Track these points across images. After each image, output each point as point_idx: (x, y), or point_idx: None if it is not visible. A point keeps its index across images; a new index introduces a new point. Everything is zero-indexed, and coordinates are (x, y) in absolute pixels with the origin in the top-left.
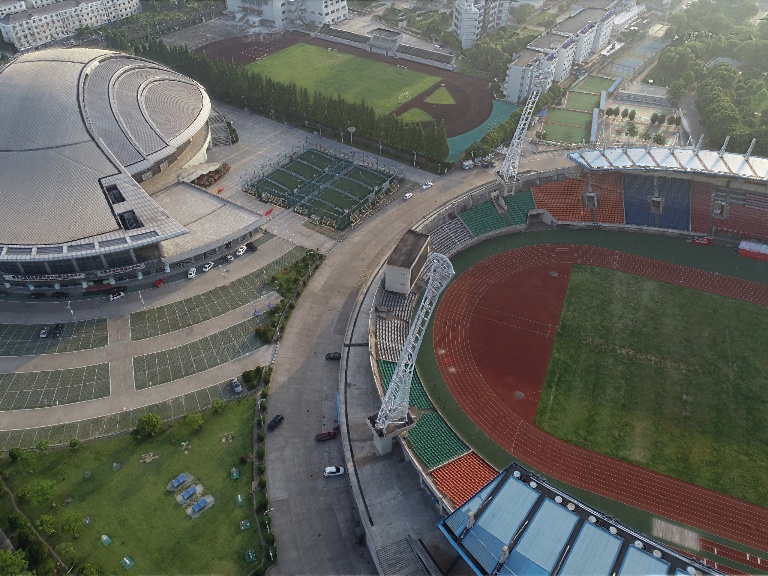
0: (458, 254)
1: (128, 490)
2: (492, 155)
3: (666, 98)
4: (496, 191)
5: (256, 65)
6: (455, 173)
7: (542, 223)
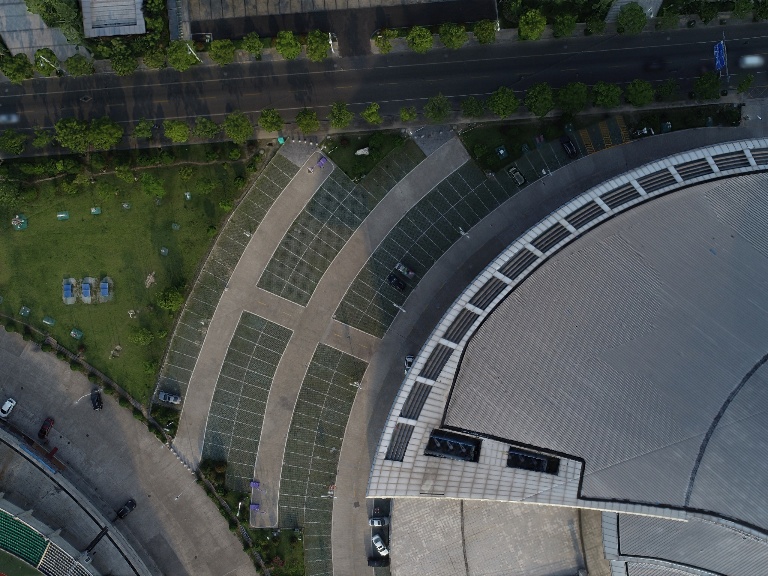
0: None
1: (131, 248)
2: None
3: None
4: None
5: None
6: None
7: None
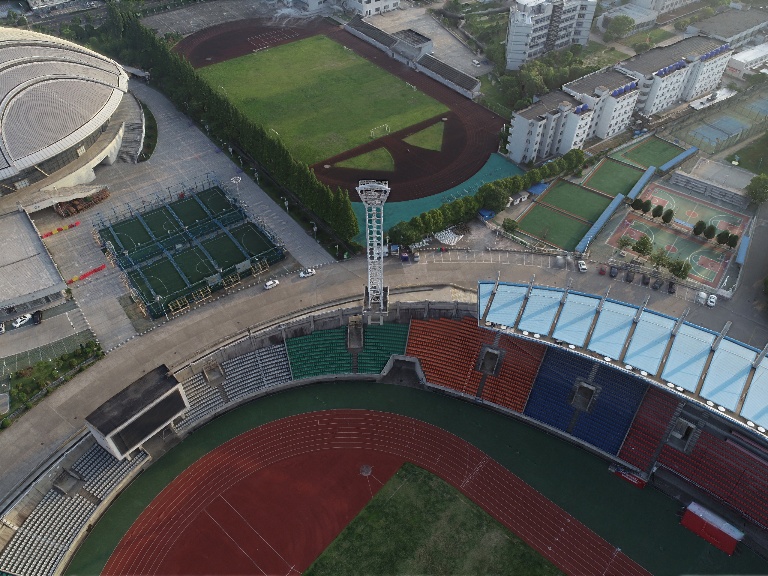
0: (264, 397)
1: None
2: (426, 242)
3: (742, 195)
4: (357, 315)
5: (250, 58)
6: (358, 260)
7: (413, 374)
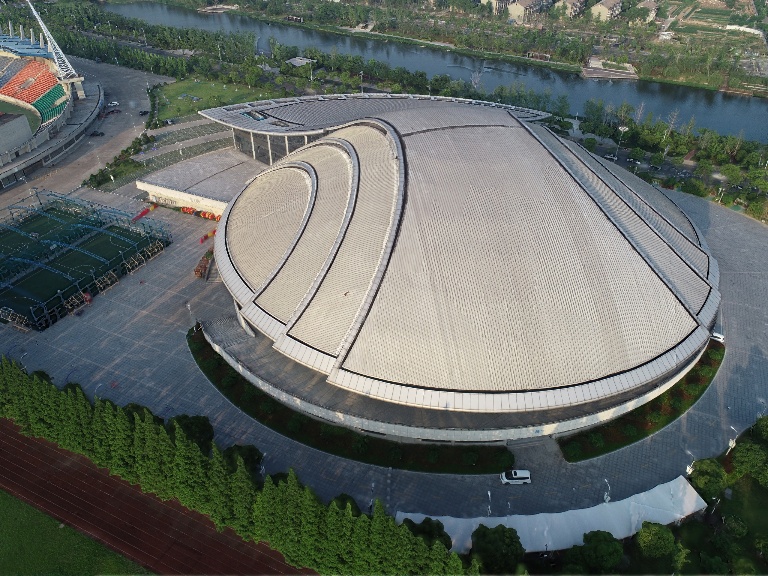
0: None
1: (221, 97)
2: None
3: None
4: None
5: None
6: None
7: None
